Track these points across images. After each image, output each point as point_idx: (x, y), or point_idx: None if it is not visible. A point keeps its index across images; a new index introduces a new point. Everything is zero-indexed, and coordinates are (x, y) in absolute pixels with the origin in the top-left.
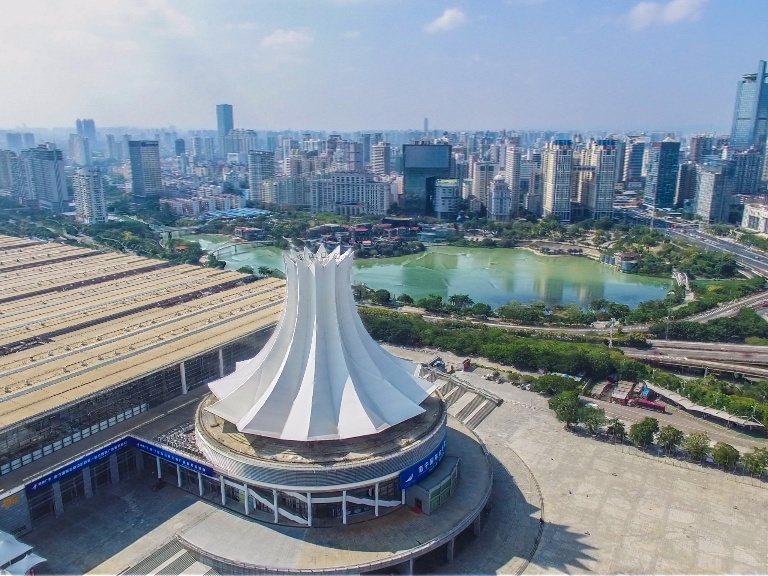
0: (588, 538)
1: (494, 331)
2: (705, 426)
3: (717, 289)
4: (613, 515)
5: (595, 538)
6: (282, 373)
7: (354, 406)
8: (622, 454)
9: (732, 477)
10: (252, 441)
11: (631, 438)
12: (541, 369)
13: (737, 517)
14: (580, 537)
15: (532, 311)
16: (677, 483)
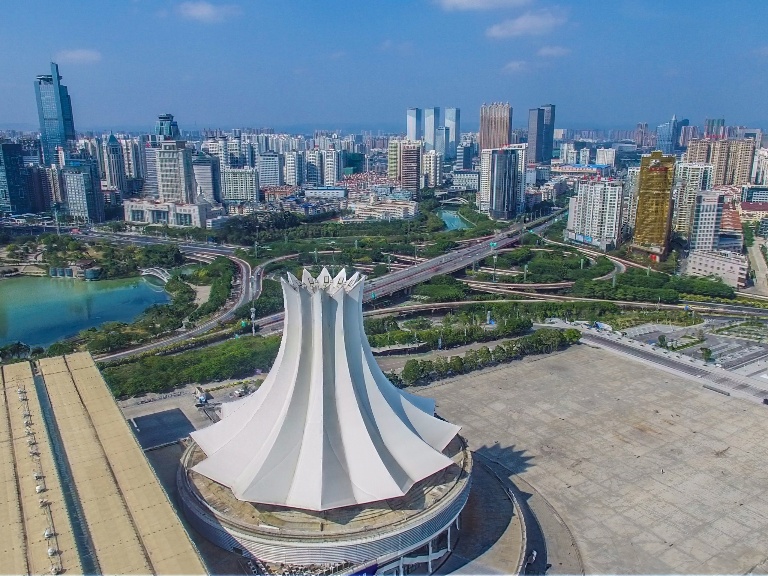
0: (502, 444)
1: (153, 358)
2: (399, 359)
3: (207, 273)
4: (483, 426)
5: (503, 441)
6: (364, 421)
7: (423, 419)
8: (415, 394)
9: (471, 375)
10: (388, 507)
11: (408, 380)
12: (259, 369)
13: (509, 392)
14: (500, 446)
15: (119, 334)
16: (463, 392)
